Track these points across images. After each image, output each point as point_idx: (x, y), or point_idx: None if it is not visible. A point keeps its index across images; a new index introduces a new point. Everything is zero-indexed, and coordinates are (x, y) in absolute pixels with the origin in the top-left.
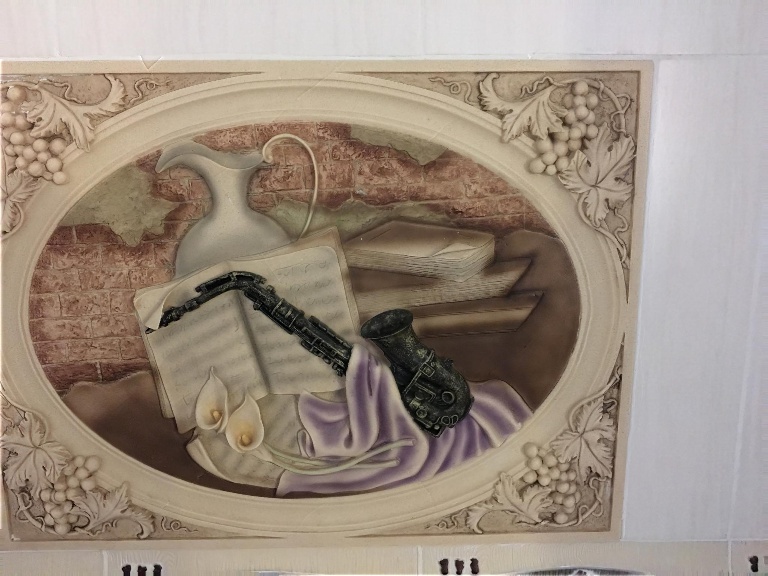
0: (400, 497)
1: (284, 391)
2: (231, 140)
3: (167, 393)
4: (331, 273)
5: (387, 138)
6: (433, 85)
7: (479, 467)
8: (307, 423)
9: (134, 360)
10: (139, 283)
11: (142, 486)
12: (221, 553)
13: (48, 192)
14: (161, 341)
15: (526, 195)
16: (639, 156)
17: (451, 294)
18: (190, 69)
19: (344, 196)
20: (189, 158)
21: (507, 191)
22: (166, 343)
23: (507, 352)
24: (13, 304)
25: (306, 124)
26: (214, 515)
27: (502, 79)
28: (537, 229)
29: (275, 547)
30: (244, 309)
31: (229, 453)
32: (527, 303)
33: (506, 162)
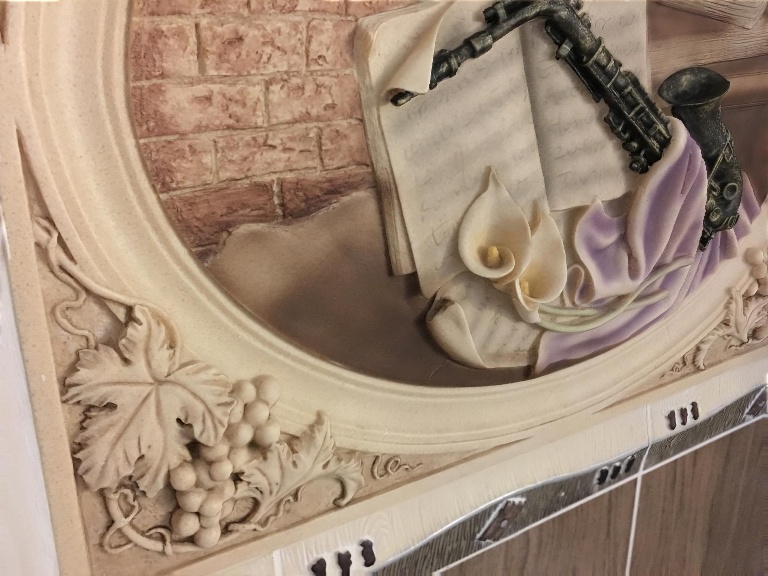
0: (642, 344)
1: (571, 203)
2: None
3: (407, 227)
4: (637, 3)
5: None
6: None
7: (710, 287)
8: (584, 252)
9: (344, 170)
10: (363, 4)
11: (343, 413)
12: (450, 488)
13: None
14: (404, 125)
15: None
16: None
17: (733, 48)
18: None
19: None
20: None
21: None
22: (412, 128)
23: (753, 133)
24: (80, 43)
25: None
26: (447, 431)
27: None
28: None
29: (515, 455)
30: (529, 61)
31: (479, 322)
32: None
33: None
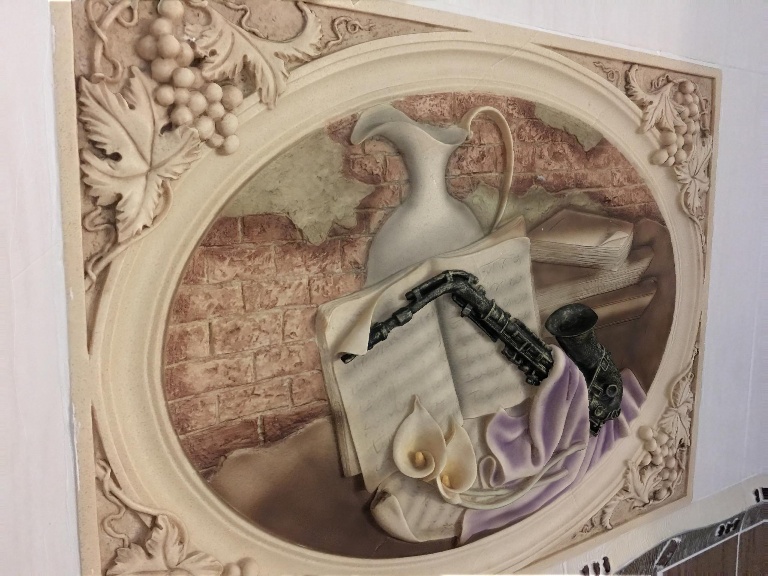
0: (553, 511)
1: (480, 412)
2: (430, 109)
3: (354, 442)
4: (522, 268)
5: (563, 120)
6: (596, 70)
7: (610, 460)
8: (494, 447)
9: (308, 405)
10: (322, 295)
11: None
12: None
13: (204, 165)
14: (351, 372)
15: (648, 185)
16: (714, 152)
17: (605, 284)
18: (400, 13)
19: (528, 182)
20: (397, 127)
21: (637, 181)
22: (357, 374)
23: (632, 339)
24: (134, 345)
25: (499, 98)
26: None
27: (640, 72)
28: (654, 218)
29: None
30: (443, 318)
31: (413, 506)
32: (652, 289)
33: (637, 152)
